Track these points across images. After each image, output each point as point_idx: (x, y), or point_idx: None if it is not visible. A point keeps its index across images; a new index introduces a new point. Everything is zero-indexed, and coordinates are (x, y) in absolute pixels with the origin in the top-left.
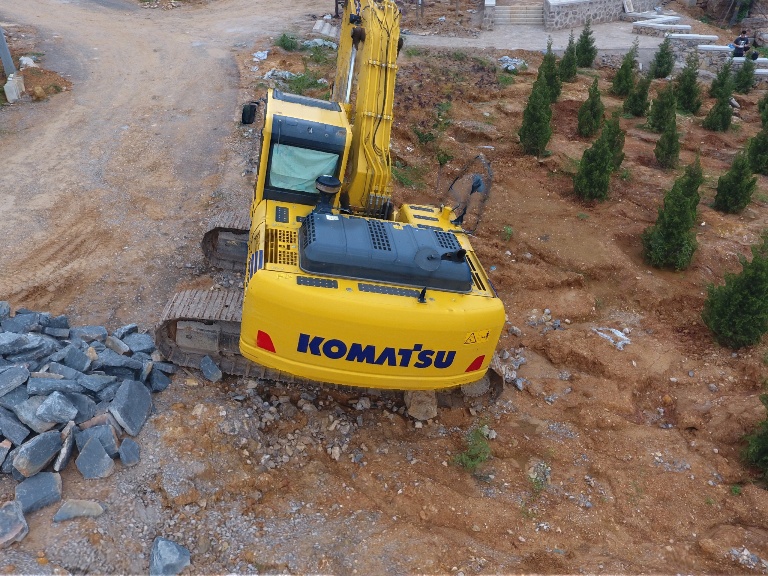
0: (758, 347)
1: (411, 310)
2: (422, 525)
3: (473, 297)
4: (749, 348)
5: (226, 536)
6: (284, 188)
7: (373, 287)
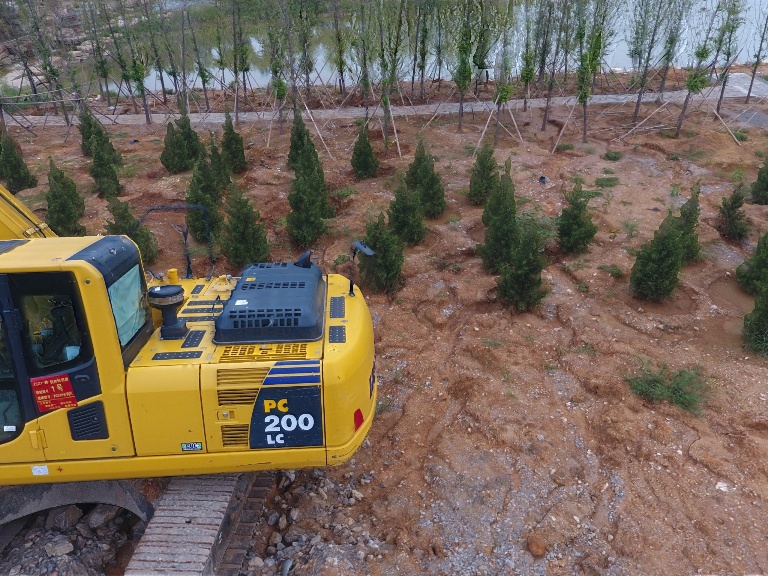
0: (272, 256)
1: (363, 303)
2: (429, 447)
3: (332, 281)
4: (270, 260)
5: (472, 569)
6: (129, 340)
7: (335, 313)
